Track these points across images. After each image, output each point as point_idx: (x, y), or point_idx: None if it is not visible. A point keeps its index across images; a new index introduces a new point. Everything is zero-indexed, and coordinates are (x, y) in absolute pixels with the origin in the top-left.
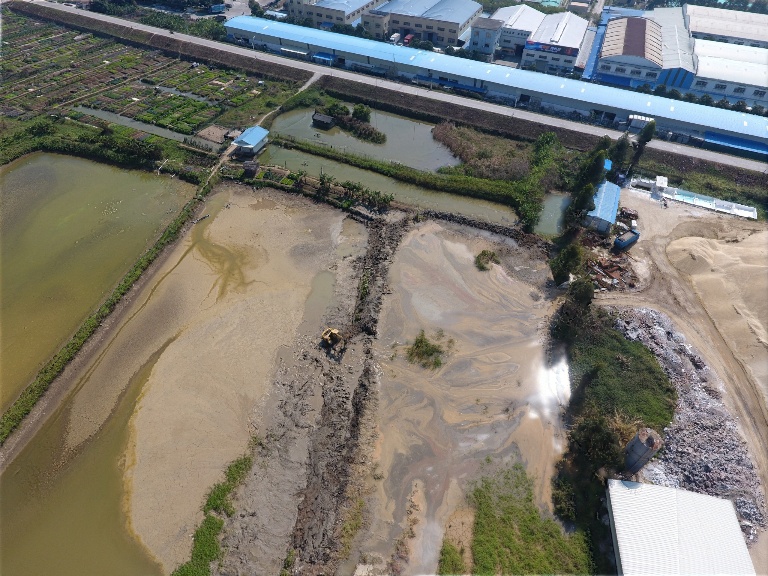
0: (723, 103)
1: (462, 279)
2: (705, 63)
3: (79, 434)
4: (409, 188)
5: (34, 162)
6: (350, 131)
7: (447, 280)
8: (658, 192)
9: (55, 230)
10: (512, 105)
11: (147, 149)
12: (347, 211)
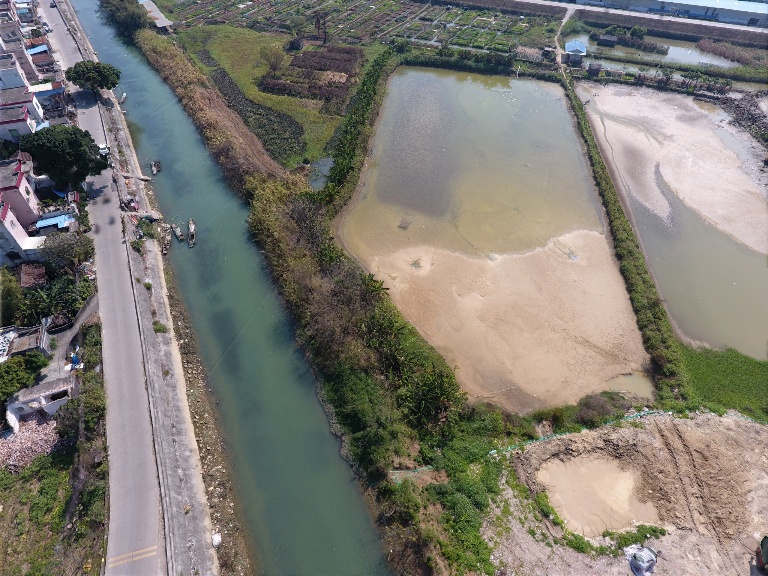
0: None
1: None
2: None
3: (661, 211)
4: None
5: (409, 72)
6: (633, 47)
7: None
8: None
9: (486, 111)
10: None
11: (504, 58)
12: (691, 95)
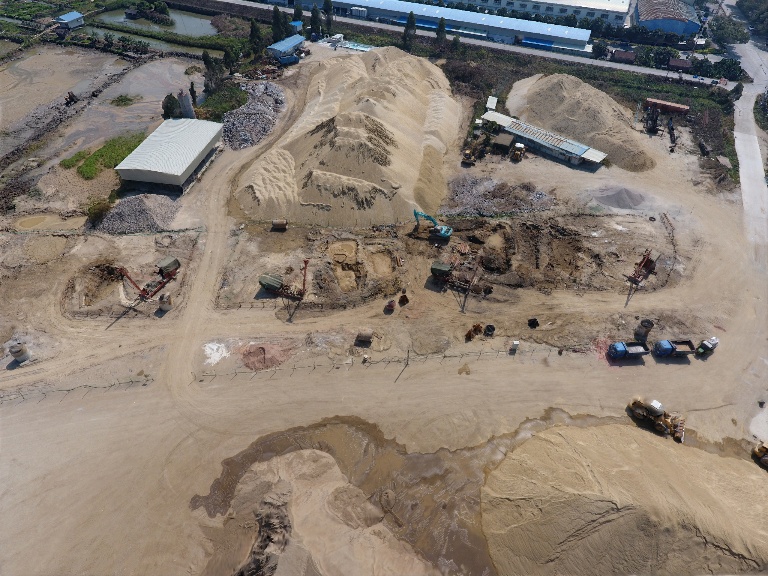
0: (429, 2)
1: (170, 77)
2: None
3: None
4: None
5: None
6: (151, 20)
7: (160, 78)
8: (336, 43)
9: None
10: None
11: None
12: (121, 55)
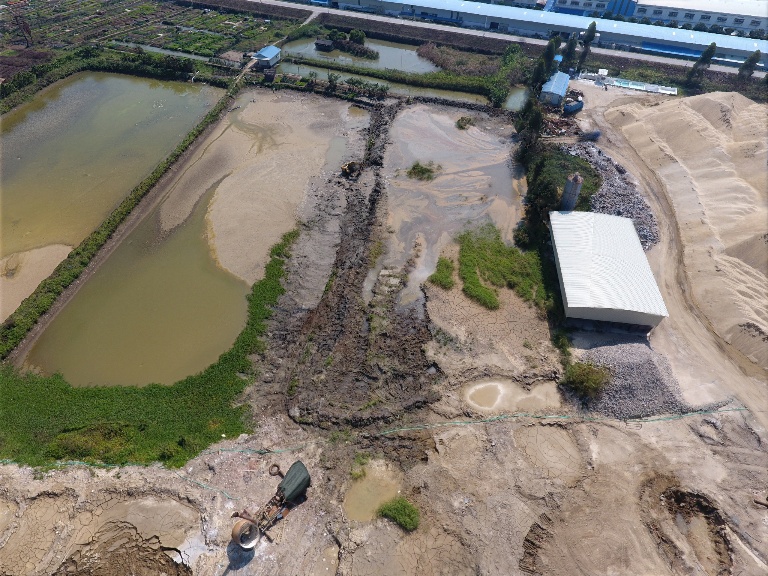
0: (659, 23)
1: (446, 134)
2: None
3: (170, 224)
4: None
5: (85, 77)
6: (348, 52)
7: (434, 135)
8: (601, 80)
9: (117, 118)
10: None
11: (181, 63)
12: (352, 101)
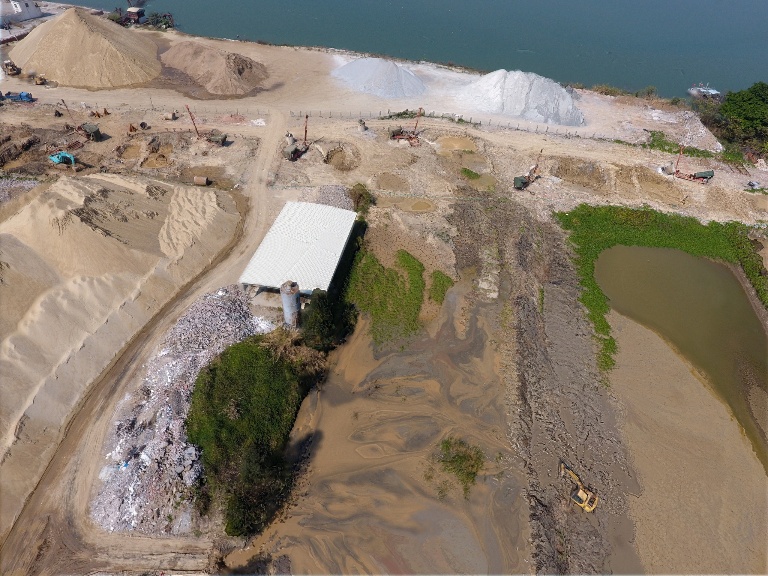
0: None
1: None
2: None
3: (760, 397)
4: None
5: None
6: None
7: None
8: None
9: None
10: None
11: None
12: None
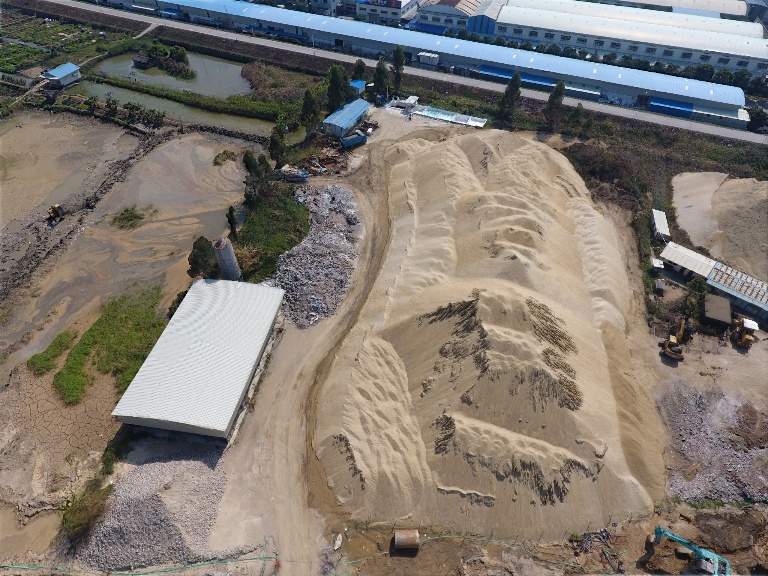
0: (512, 44)
1: (194, 171)
2: (506, 11)
3: None
4: (199, 113)
5: None
6: (165, 70)
7: (180, 172)
8: (409, 109)
9: None
10: (326, 49)
11: None
12: (127, 128)
